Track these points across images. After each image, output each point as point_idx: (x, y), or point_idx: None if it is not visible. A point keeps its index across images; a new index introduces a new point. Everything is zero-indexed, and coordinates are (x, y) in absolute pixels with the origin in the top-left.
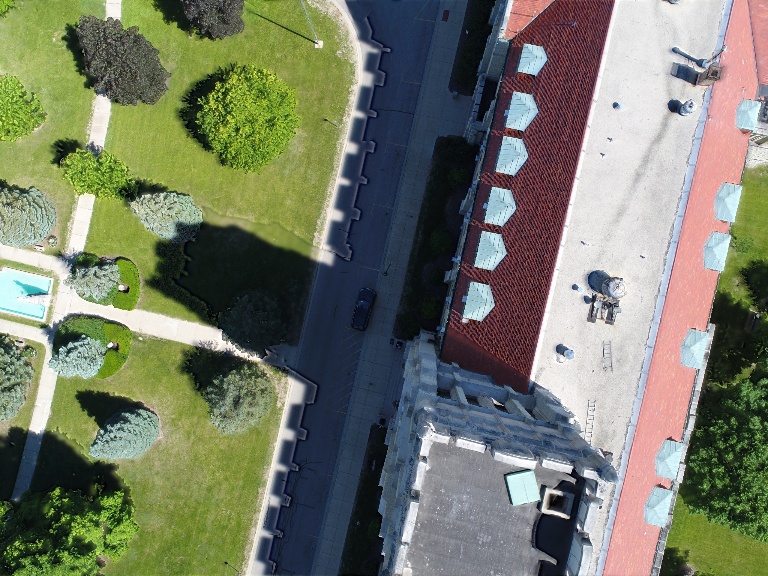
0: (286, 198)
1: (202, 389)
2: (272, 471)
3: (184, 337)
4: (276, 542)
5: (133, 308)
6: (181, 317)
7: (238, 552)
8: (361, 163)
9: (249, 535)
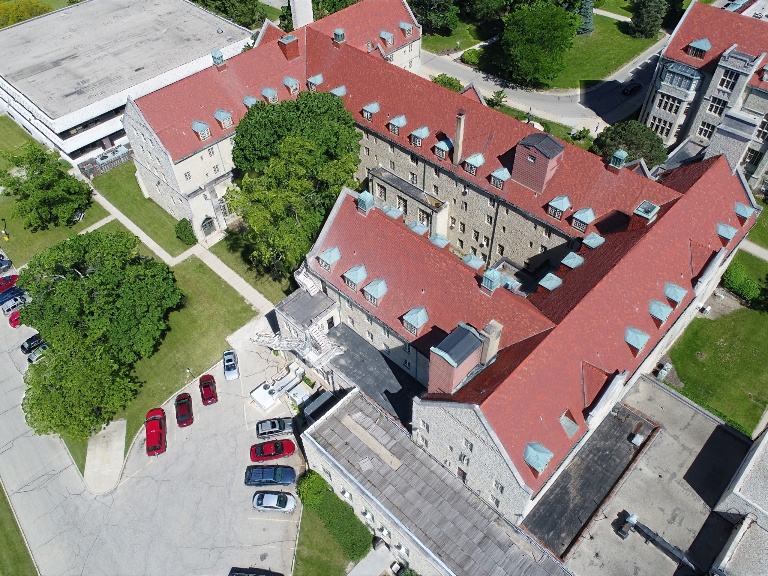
0: (685, 3)
1: (619, 29)
2: (645, 53)
3: (617, 18)
4: (637, 69)
5: (596, 8)
6: (619, 14)
7: (614, 67)
8: (725, 4)
9: (623, 64)
